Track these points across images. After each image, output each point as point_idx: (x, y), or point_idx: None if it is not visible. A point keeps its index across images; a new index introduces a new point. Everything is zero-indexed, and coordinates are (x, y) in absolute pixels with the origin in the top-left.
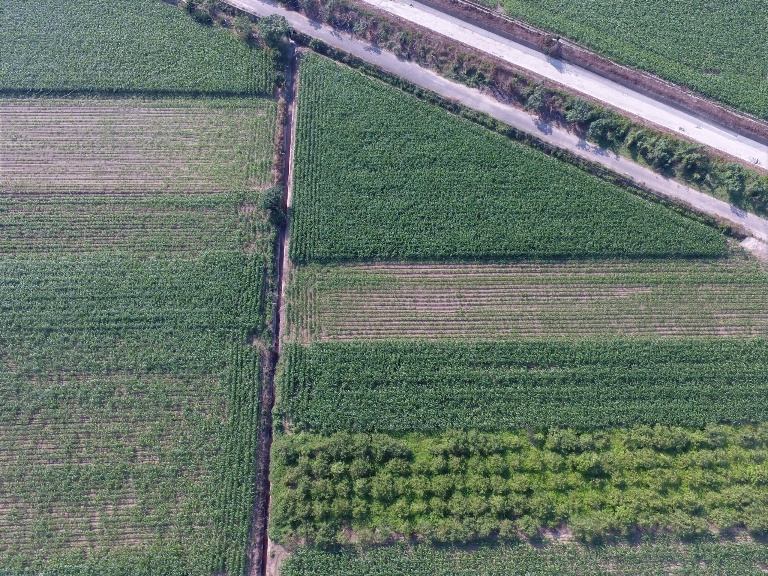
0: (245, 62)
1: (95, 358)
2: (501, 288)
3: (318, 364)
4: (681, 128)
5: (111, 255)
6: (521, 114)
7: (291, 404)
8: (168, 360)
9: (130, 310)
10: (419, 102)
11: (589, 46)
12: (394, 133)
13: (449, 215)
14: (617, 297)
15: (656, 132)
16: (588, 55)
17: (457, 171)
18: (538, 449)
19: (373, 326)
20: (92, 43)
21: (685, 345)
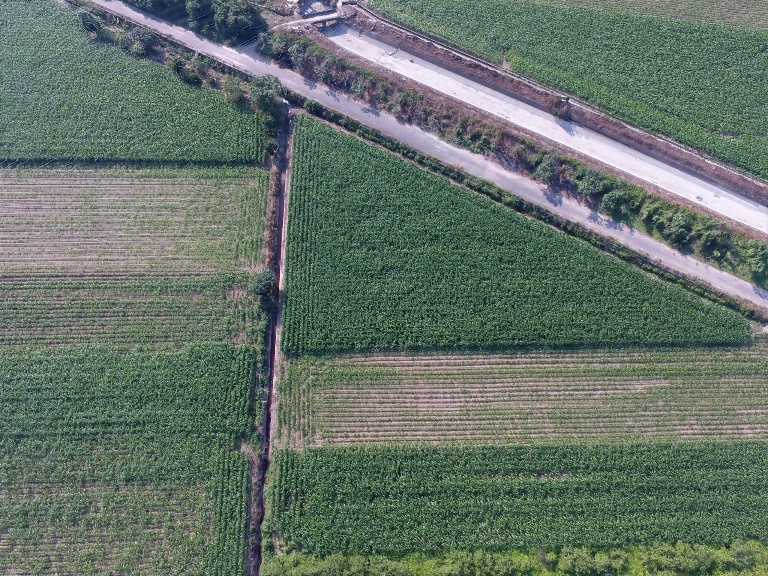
0: (235, 127)
1: (70, 468)
2: (509, 382)
3: (311, 474)
4: (698, 197)
5: (89, 348)
6: (529, 183)
7: (282, 521)
8: (149, 470)
9: (108, 413)
10: (420, 171)
11: (600, 106)
12: (394, 206)
13: (453, 300)
14: (633, 391)
15: (673, 205)
16: (599, 117)
17: (461, 249)
18: (550, 570)
19: (371, 427)
20: (73, 107)
21: (707, 448)
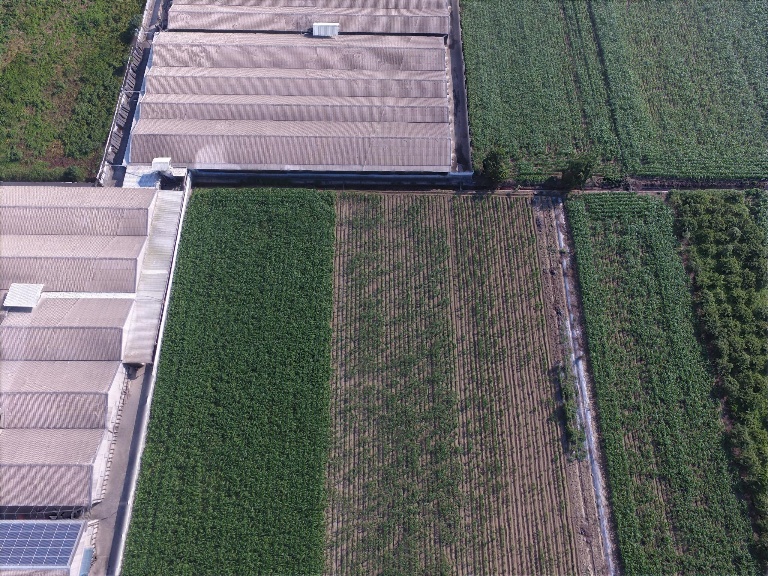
0: None
1: (760, 75)
2: None
3: None
4: None
5: None
6: None
7: None
8: None
9: None
10: None
11: None
12: None
13: None
14: None
15: None
16: None
17: None
18: None
19: None
20: None
21: None
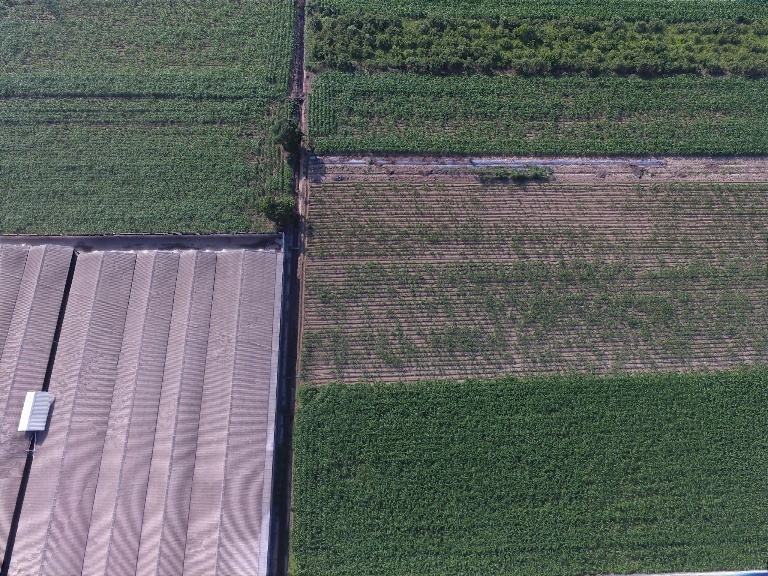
0: None
1: None
2: None
3: None
4: None
5: None
6: None
7: None
8: None
9: None
10: None
11: None
12: None
13: None
14: None
15: None
16: None
17: None
18: None
19: None
20: None
21: None
